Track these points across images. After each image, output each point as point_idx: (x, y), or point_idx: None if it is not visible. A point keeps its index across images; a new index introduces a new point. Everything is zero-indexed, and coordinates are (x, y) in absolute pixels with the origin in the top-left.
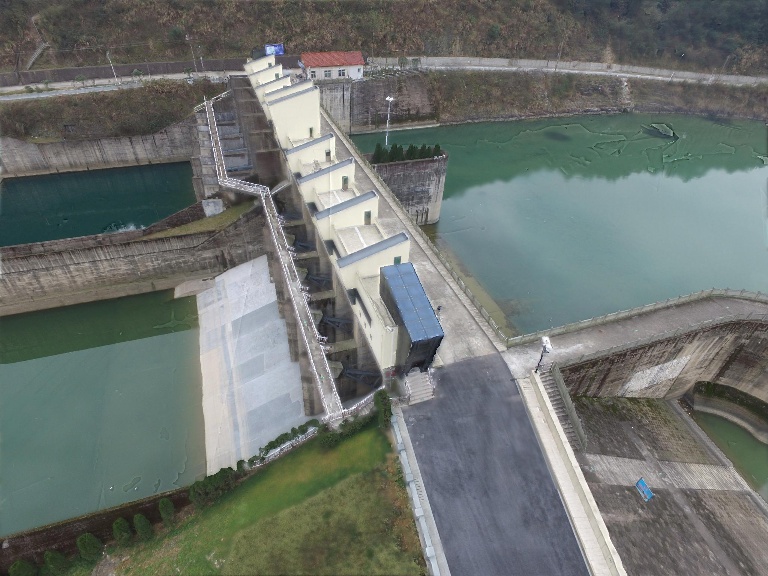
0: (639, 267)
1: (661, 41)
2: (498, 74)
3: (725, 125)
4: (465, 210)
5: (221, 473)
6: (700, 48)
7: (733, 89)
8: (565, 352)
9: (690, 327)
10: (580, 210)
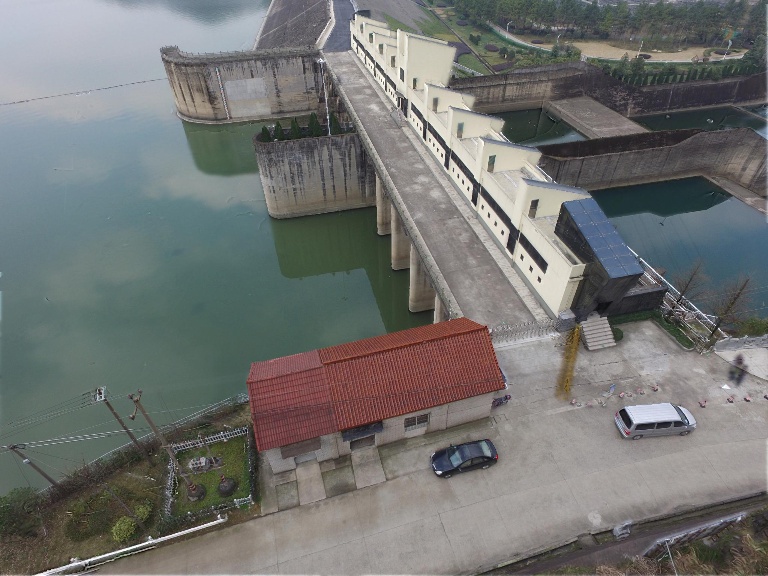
0: (128, 171)
1: None
2: None
3: None
4: (230, 221)
5: None
6: None
7: None
8: None
9: (235, 52)
10: (84, 226)
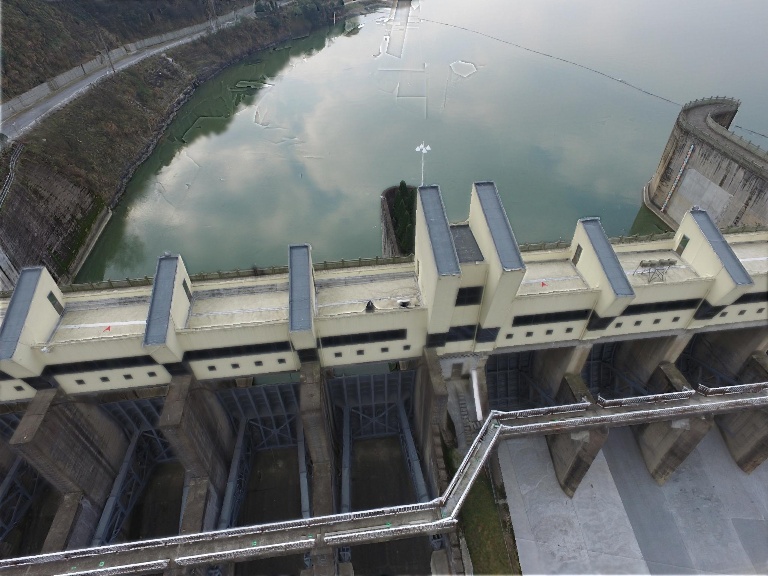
0: (504, 171)
1: (142, 4)
2: (80, 105)
3: (251, 63)
4: None
5: None
6: (173, 1)
7: (233, 30)
8: None
9: None
10: (401, 171)
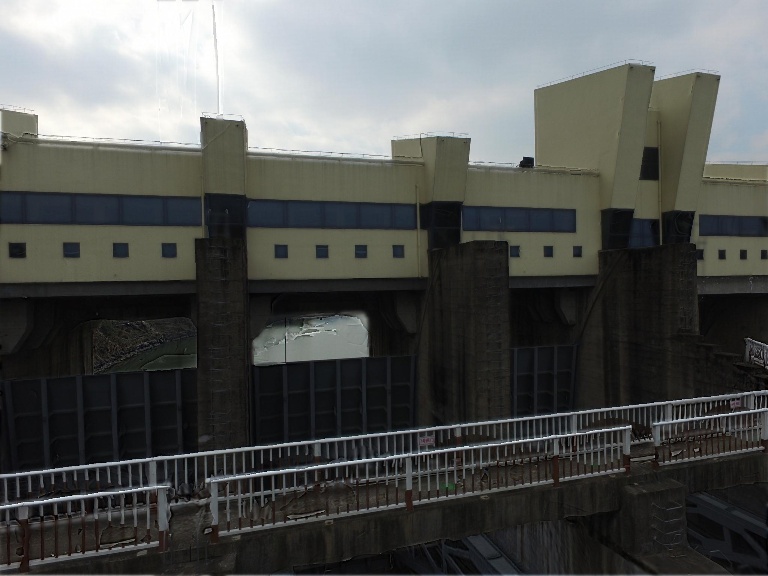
0: None
1: None
2: None
3: None
4: None
5: None
6: None
7: None
8: None
9: None
10: None
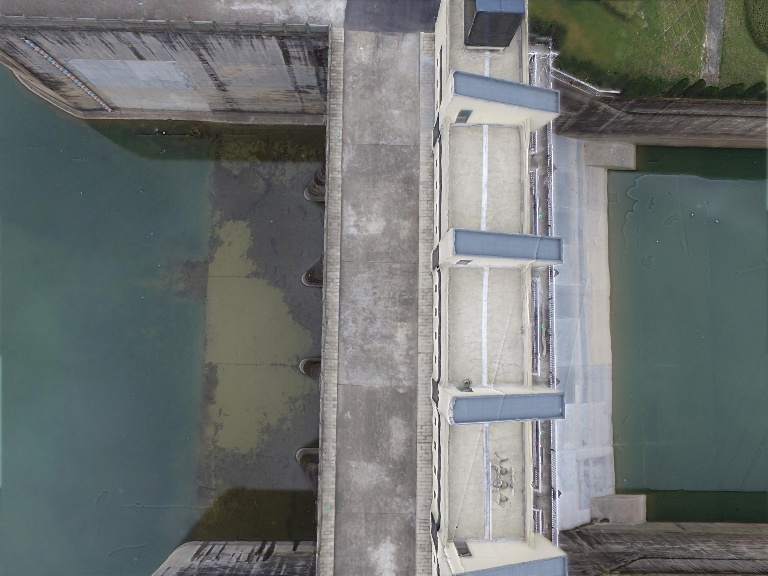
0: None
1: None
2: None
3: None
4: None
5: (641, 79)
6: None
7: None
8: (262, 3)
9: None
10: None
